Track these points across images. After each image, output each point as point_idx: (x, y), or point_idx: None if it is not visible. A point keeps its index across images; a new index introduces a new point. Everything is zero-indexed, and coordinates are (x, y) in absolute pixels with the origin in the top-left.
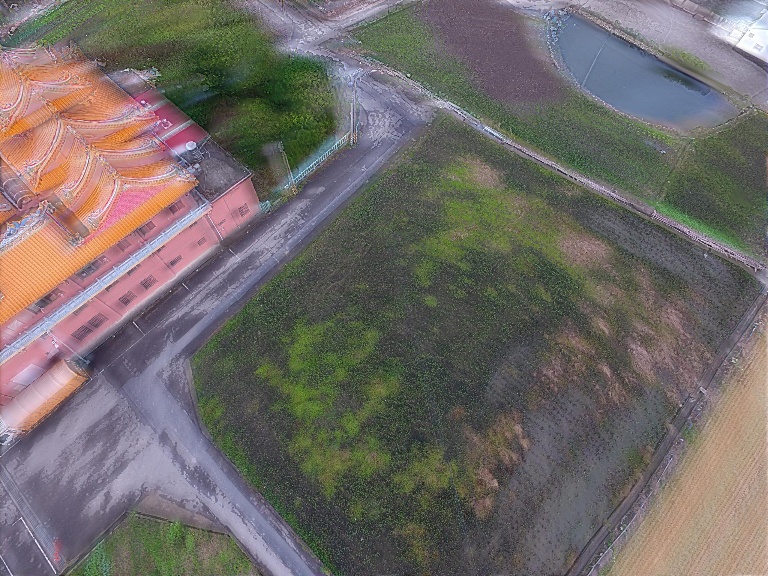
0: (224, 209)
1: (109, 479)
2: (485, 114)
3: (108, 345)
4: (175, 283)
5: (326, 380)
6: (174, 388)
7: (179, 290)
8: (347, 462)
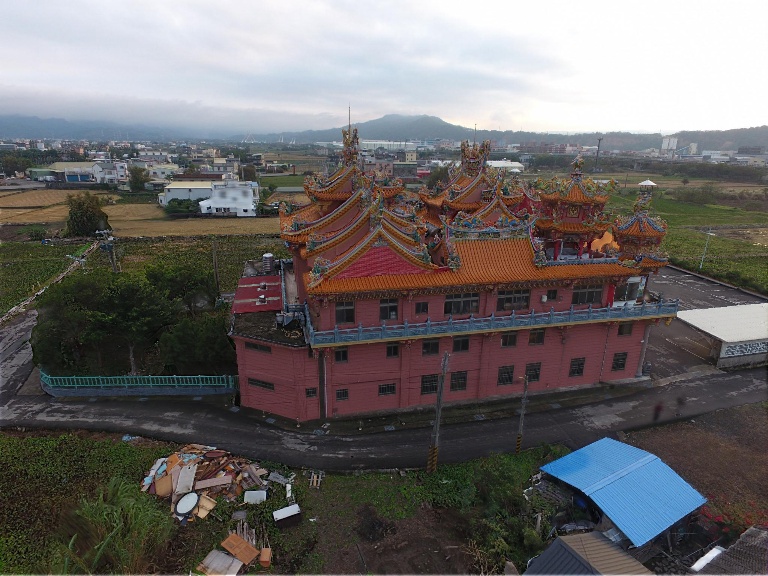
0: None
1: None
2: (14, 300)
3: None
4: None
5: None
6: None
7: None
8: None
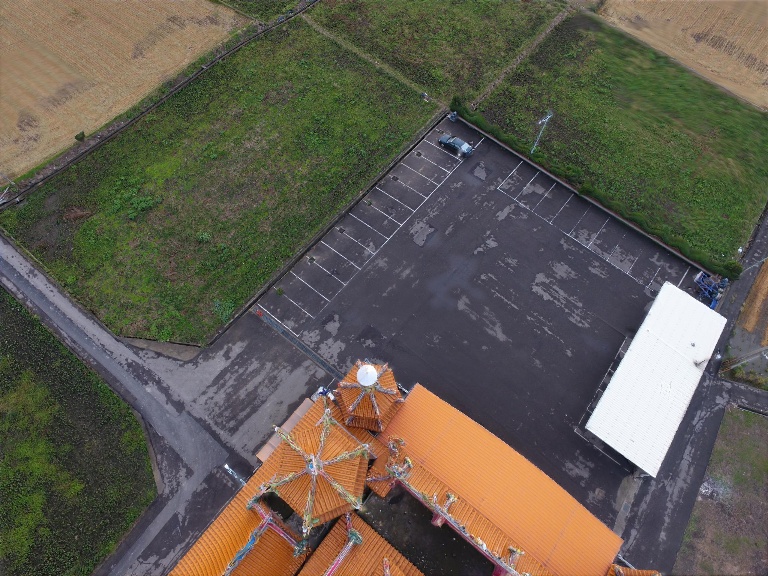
0: None
1: (228, 369)
2: None
3: None
4: None
5: (5, 483)
6: (173, 458)
7: None
8: (3, 401)
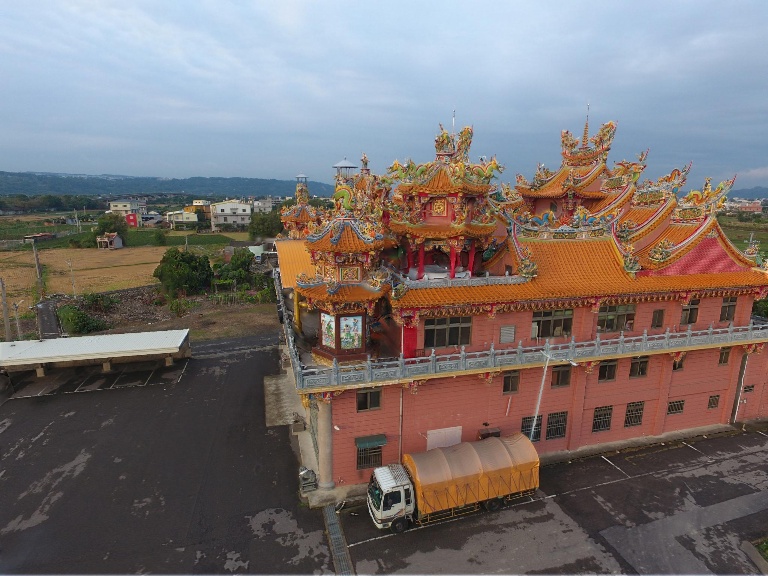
0: (763, 366)
1: None
2: None
3: (560, 468)
4: (663, 441)
5: None
6: None
7: (680, 447)
8: None
